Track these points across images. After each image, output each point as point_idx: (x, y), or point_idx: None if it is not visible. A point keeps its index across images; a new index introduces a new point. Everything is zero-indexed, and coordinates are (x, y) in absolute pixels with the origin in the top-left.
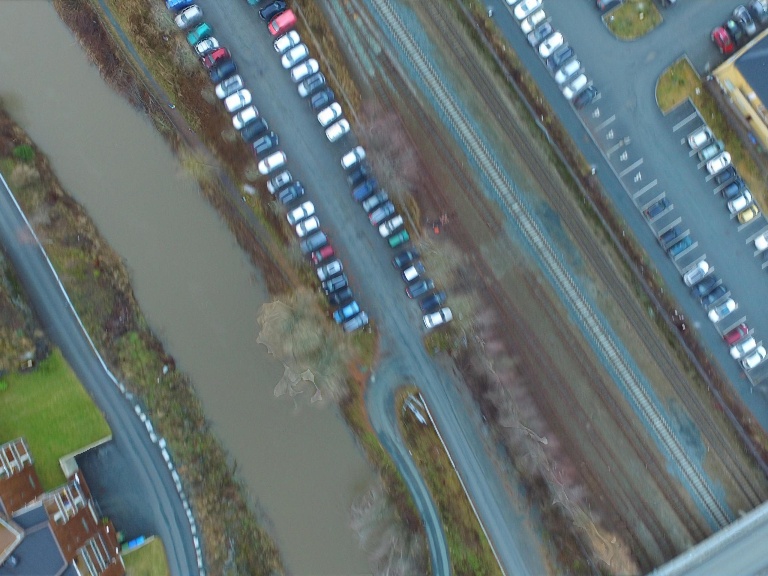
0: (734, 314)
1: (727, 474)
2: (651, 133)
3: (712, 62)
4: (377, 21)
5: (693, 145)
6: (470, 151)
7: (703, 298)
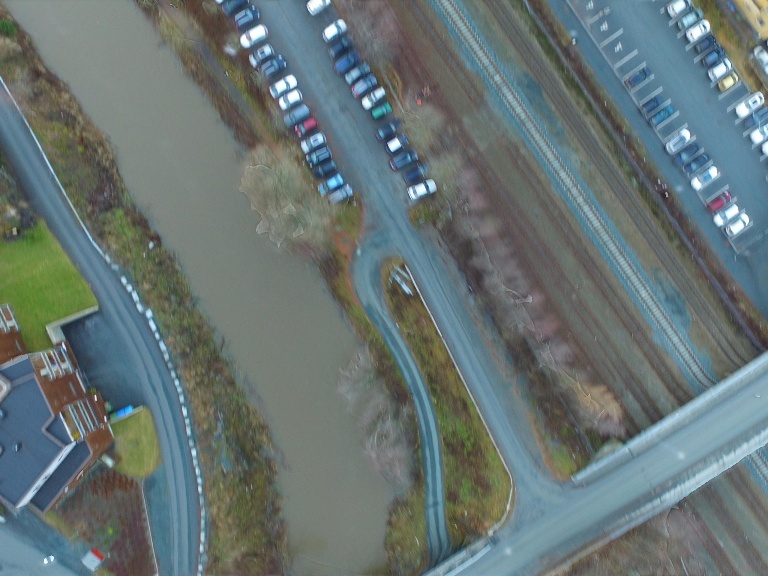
0: (717, 182)
1: (713, 343)
2: (631, 3)
3: None
4: None
5: (672, 13)
6: (451, 23)
7: (685, 166)
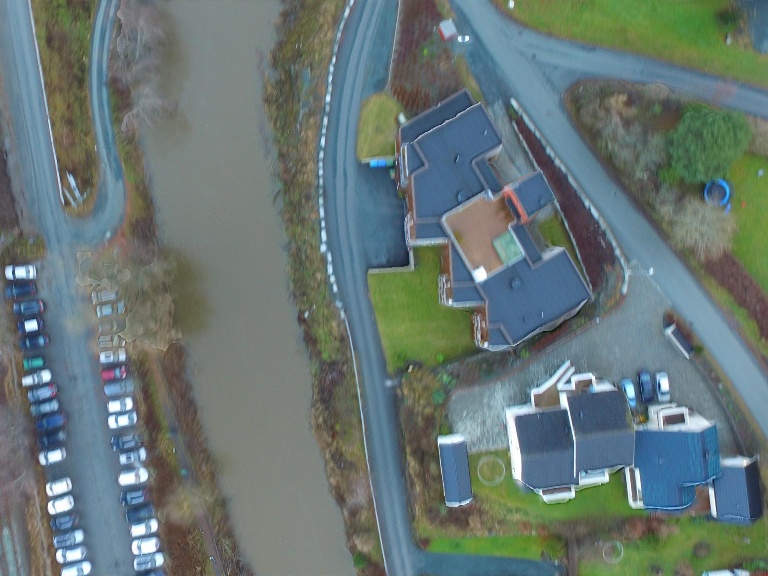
0: None
1: None
2: None
3: None
4: None
5: None
6: None
7: None
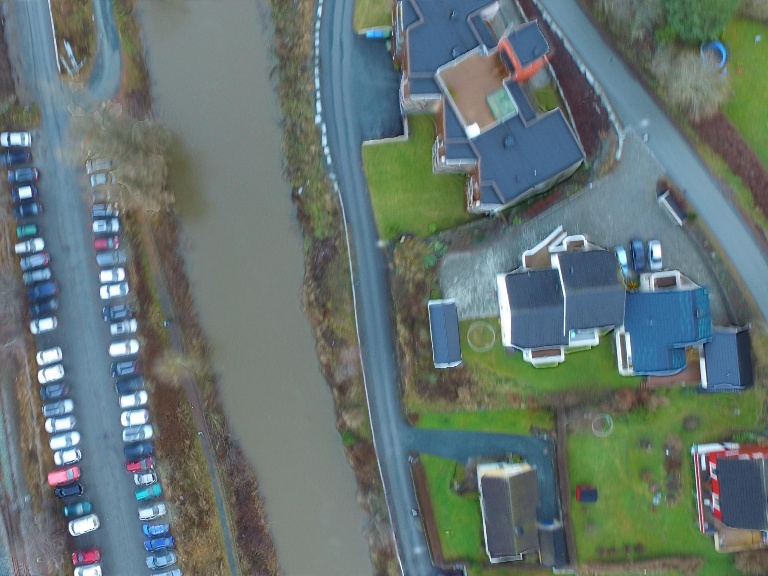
0: None
1: None
2: None
3: None
4: None
5: None
6: None
7: None
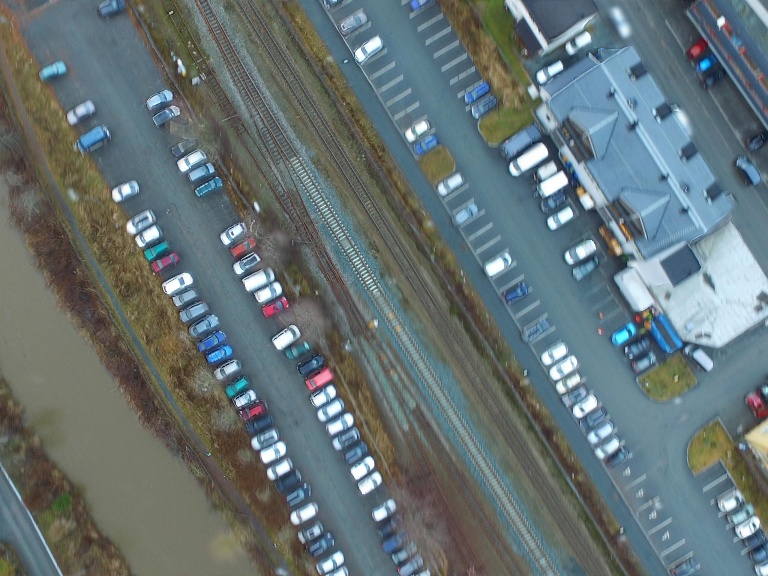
0: None
1: None
2: (681, 493)
3: (745, 424)
4: (413, 377)
5: (723, 509)
6: (500, 506)
7: None
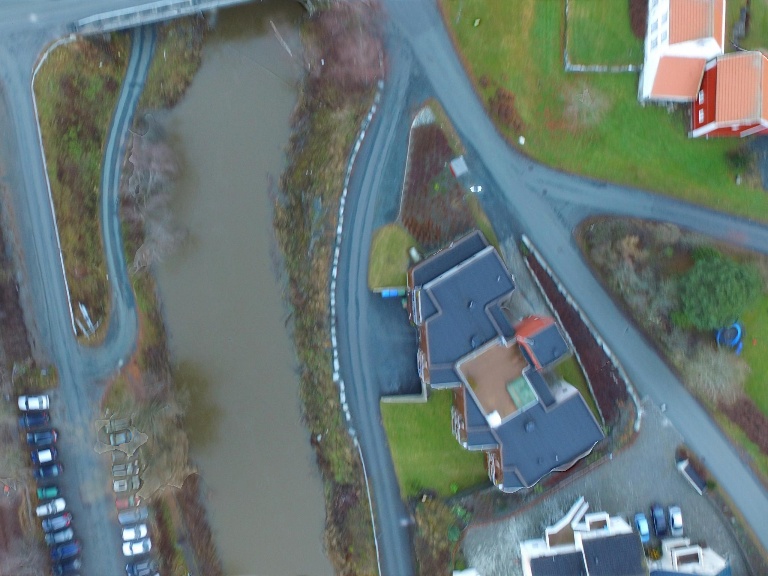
0: None
1: None
2: None
3: None
4: None
5: None
6: None
7: None
